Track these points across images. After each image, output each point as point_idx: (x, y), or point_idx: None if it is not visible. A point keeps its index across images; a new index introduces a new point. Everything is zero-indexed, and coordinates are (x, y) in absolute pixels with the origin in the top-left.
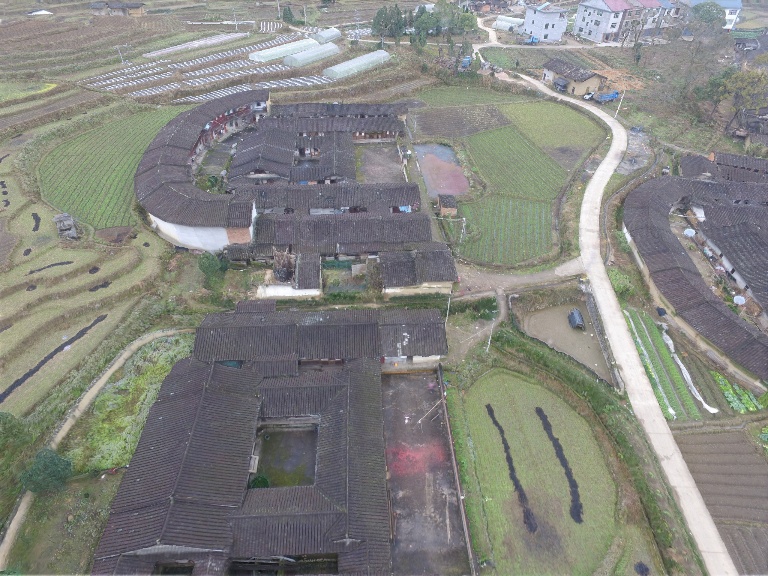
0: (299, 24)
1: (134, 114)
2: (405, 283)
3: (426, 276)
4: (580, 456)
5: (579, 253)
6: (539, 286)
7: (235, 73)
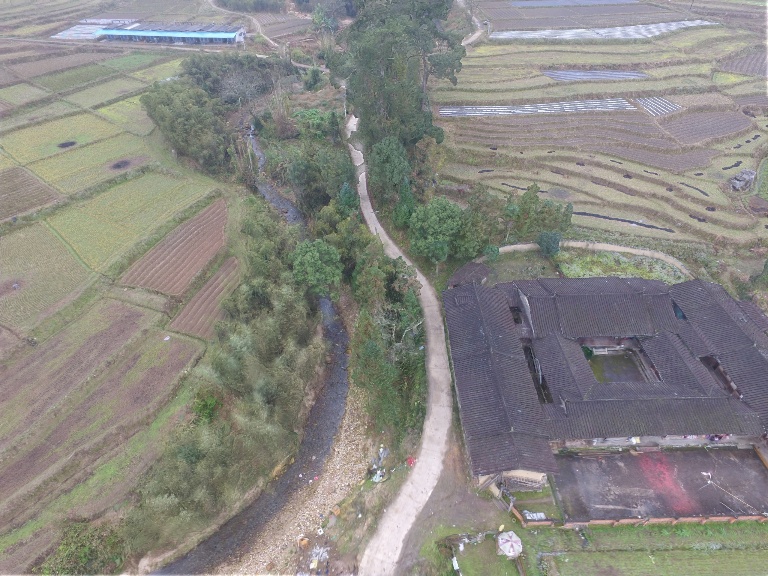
0: None
1: None
2: None
3: None
4: None
5: None
6: None
7: None
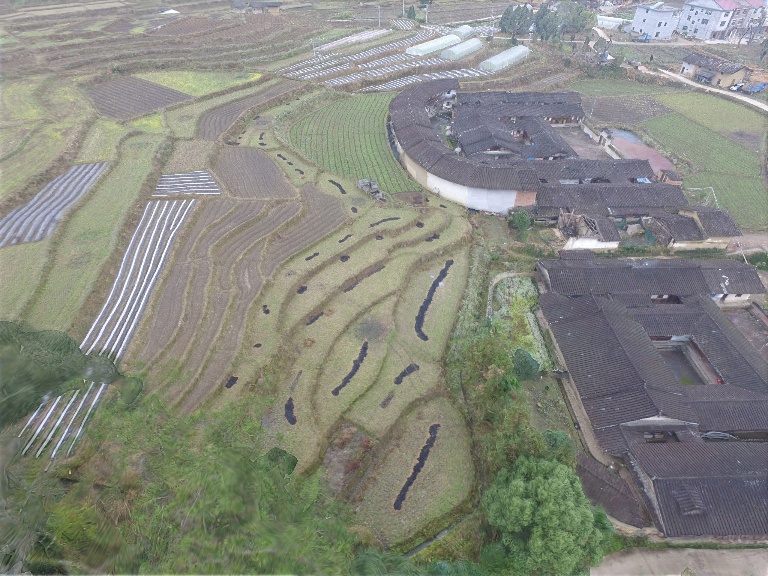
0: (420, 22)
1: (335, 101)
2: (694, 238)
3: (714, 232)
4: None
5: None
6: None
7: (402, 65)
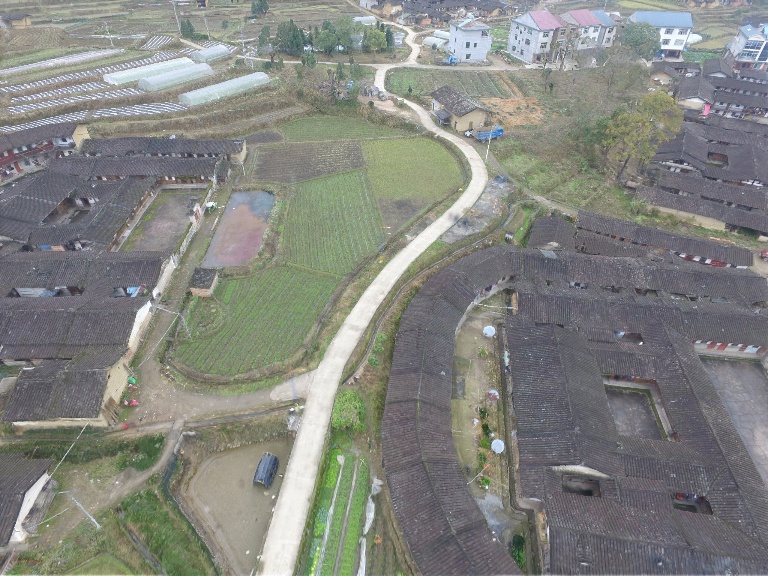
0: (202, 38)
1: None
2: (32, 416)
3: (56, 409)
4: None
5: (318, 364)
6: (236, 416)
7: (75, 98)
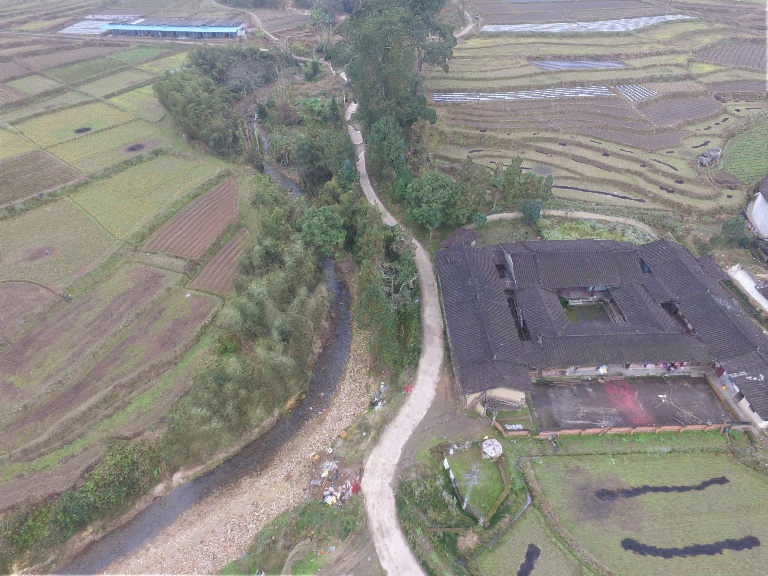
0: None
1: None
2: None
3: None
4: (709, 575)
5: None
6: None
7: None
